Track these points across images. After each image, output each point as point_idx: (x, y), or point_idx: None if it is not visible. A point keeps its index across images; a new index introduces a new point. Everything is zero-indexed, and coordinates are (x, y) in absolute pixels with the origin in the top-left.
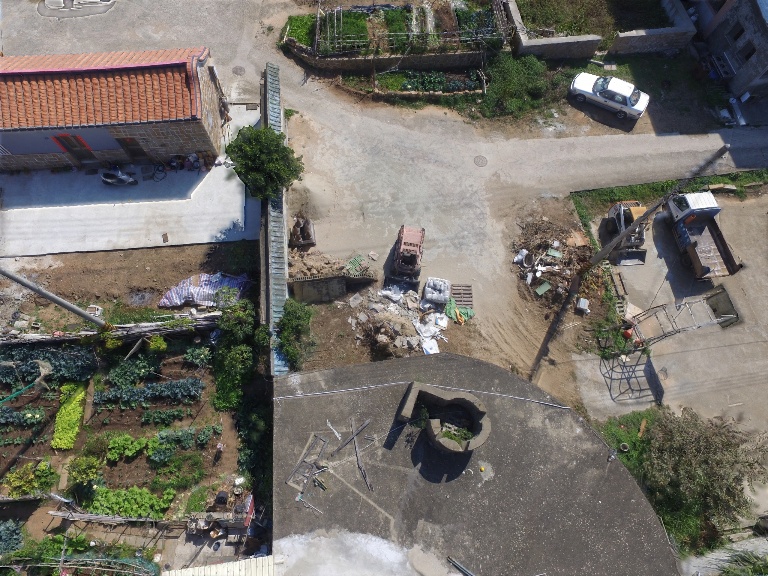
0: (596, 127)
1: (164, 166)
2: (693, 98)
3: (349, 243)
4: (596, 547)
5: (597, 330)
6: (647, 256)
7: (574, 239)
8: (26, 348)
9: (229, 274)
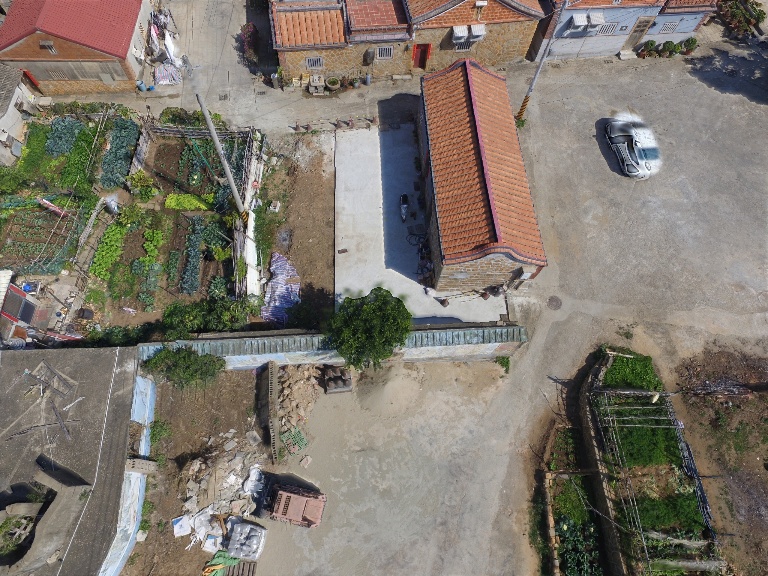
0: None
1: None
2: None
3: (325, 432)
4: None
5: None
6: None
7: None
8: None
9: None
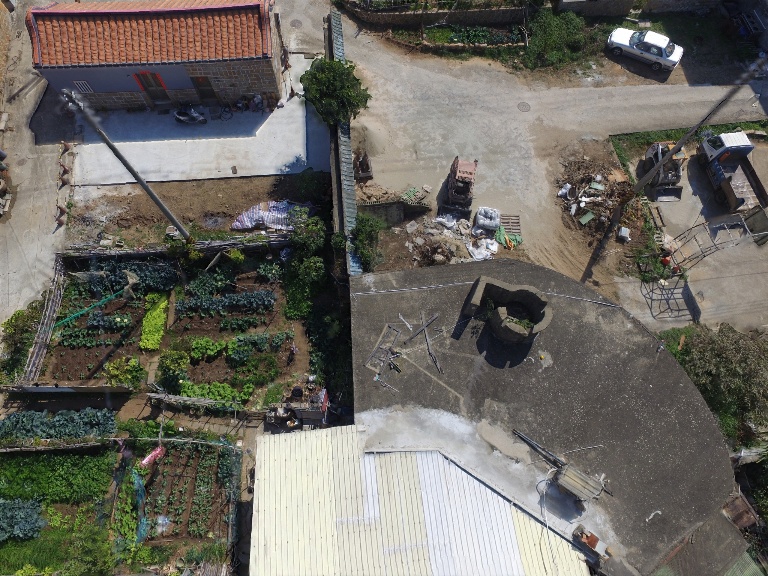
0: (632, 78)
1: (230, 107)
2: (724, 53)
3: (404, 177)
4: (648, 424)
5: (637, 256)
6: (683, 193)
7: (614, 176)
8: (114, 261)
9: (295, 201)
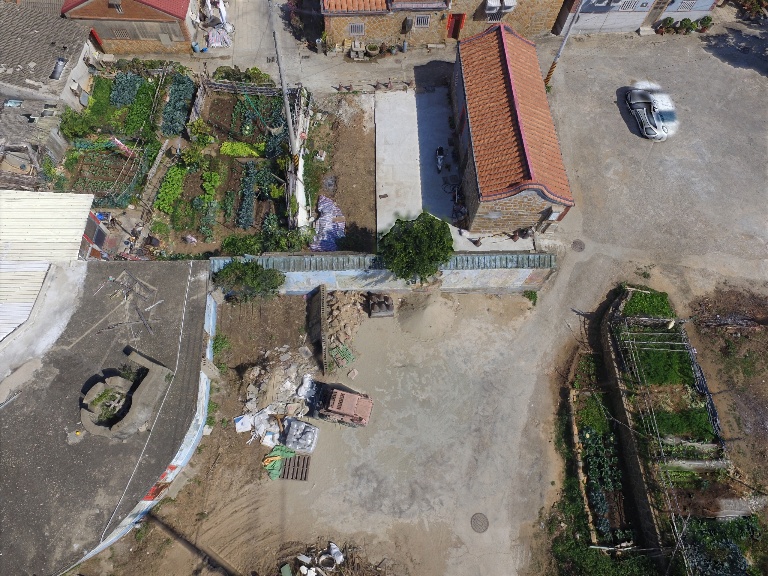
0: None
1: None
2: None
3: (370, 350)
4: None
5: None
6: None
7: None
8: None
9: None
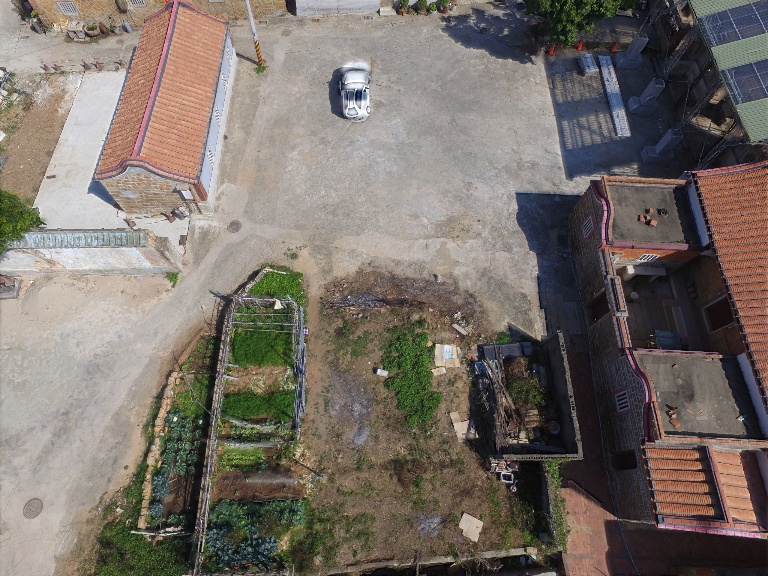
0: None
1: None
2: None
3: None
4: None
5: None
6: None
7: None
8: None
9: None
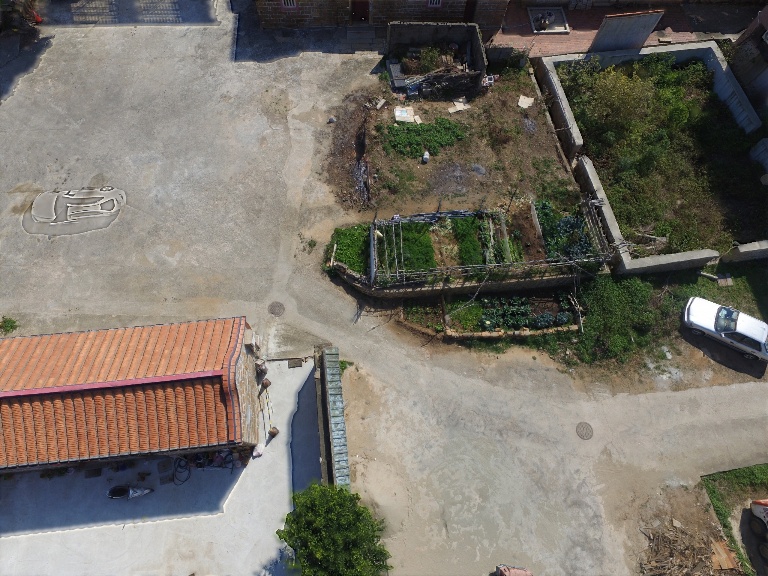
0: (719, 372)
1: None
2: None
3: (431, 575)
4: None
5: None
6: None
7: (717, 557)
8: None
9: None
